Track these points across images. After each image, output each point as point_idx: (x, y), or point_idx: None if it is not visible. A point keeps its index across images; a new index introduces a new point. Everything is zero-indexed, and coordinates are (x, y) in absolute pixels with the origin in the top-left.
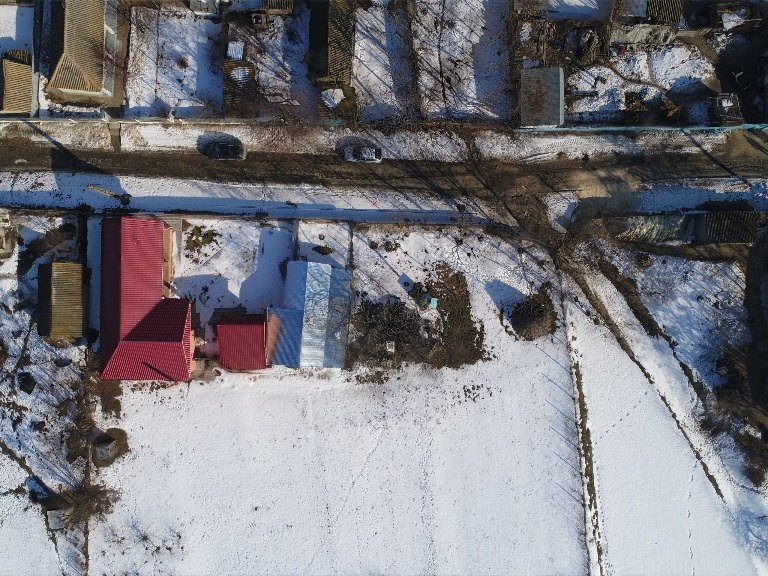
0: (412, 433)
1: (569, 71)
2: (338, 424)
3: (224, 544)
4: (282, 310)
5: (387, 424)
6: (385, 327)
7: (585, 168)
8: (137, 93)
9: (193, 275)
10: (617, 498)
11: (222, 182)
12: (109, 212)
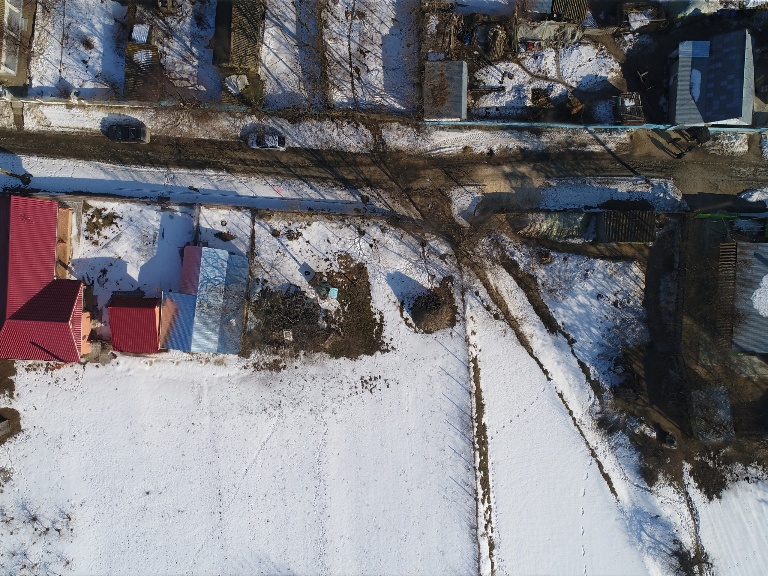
0: (307, 422)
1: (477, 65)
2: (233, 411)
3: (114, 527)
4: (176, 294)
5: (283, 412)
6: (282, 315)
7: (490, 163)
8: (41, 73)
9: (92, 257)
10: (511, 493)
11: (125, 165)
12: (9, 191)
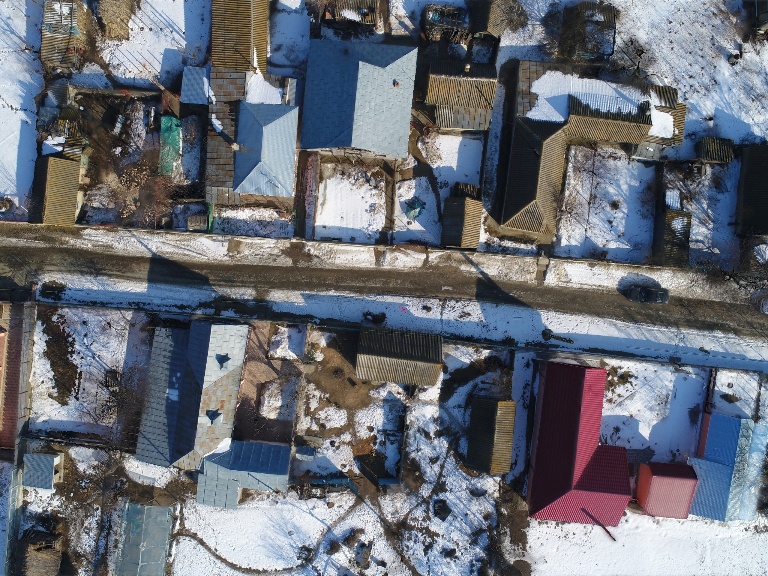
0: None
1: None
2: (734, 572)
3: None
4: (707, 462)
5: None
6: None
7: None
8: (569, 231)
9: (607, 415)
10: None
11: (637, 323)
12: (531, 346)
